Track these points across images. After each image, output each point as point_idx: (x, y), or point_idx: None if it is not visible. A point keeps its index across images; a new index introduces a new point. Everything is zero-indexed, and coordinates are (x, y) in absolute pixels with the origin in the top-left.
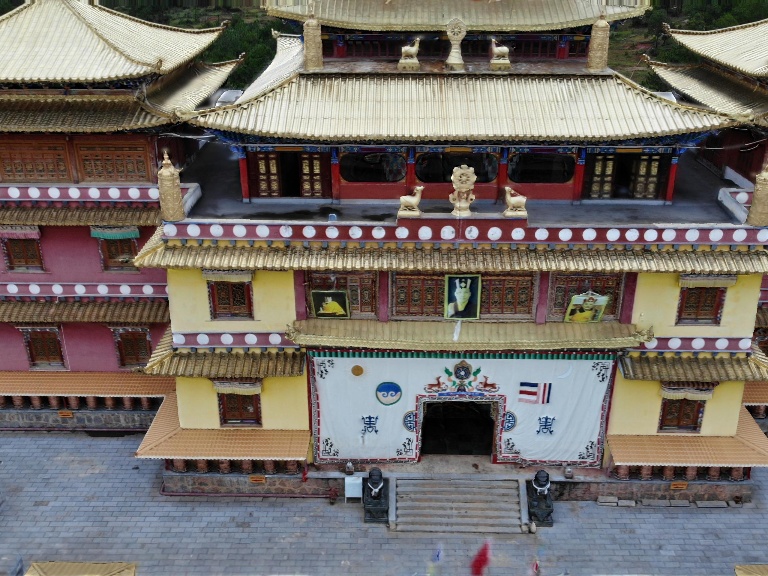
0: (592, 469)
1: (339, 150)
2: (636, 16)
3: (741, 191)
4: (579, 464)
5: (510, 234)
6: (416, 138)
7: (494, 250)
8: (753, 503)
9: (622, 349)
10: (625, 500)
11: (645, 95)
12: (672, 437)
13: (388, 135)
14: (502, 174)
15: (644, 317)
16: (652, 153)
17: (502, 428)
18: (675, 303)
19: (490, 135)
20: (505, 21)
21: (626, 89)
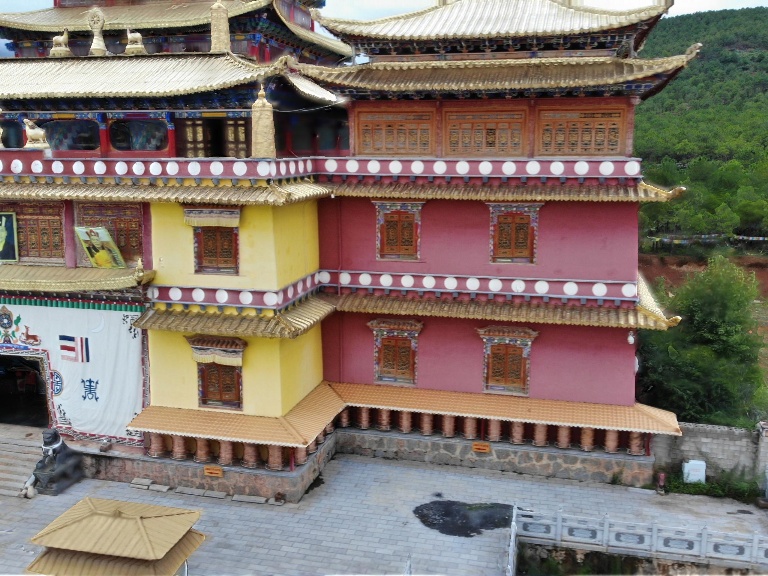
0: (138, 448)
1: None
2: (268, 6)
3: (329, 158)
4: (129, 442)
5: (30, 167)
6: (7, 96)
7: (16, 183)
8: (298, 504)
9: (147, 299)
10: (160, 485)
11: (239, 65)
12: (212, 412)
13: None
14: (102, 140)
15: (164, 262)
16: (236, 118)
17: (52, 391)
18: (191, 247)
19: (68, 92)
20: (162, 19)
21: (229, 62)
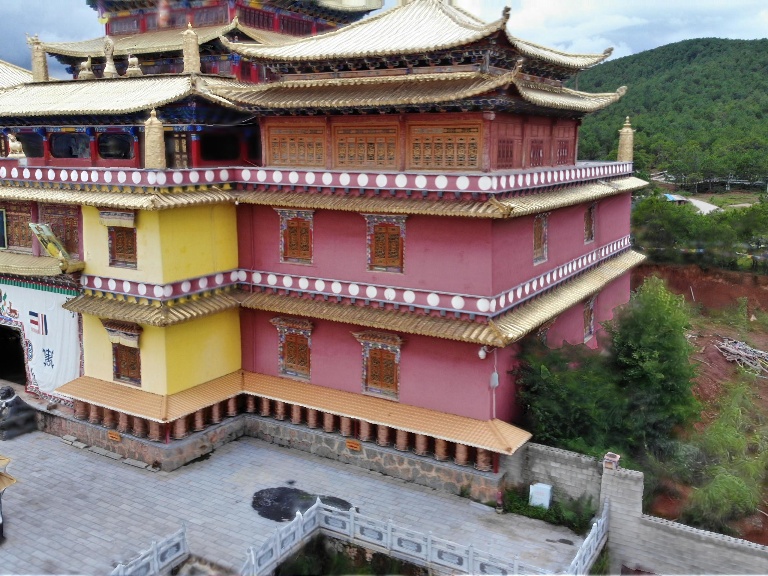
0: None
1: (12, 131)
2: (234, 30)
3: (245, 168)
4: (72, 404)
5: (11, 173)
6: (25, 114)
7: (2, 186)
8: (169, 473)
9: (80, 286)
10: (81, 442)
11: None
12: (120, 386)
13: (12, 112)
14: (92, 150)
15: (90, 255)
16: (180, 131)
17: (28, 357)
18: (107, 243)
19: (61, 110)
20: None
21: (187, 82)
